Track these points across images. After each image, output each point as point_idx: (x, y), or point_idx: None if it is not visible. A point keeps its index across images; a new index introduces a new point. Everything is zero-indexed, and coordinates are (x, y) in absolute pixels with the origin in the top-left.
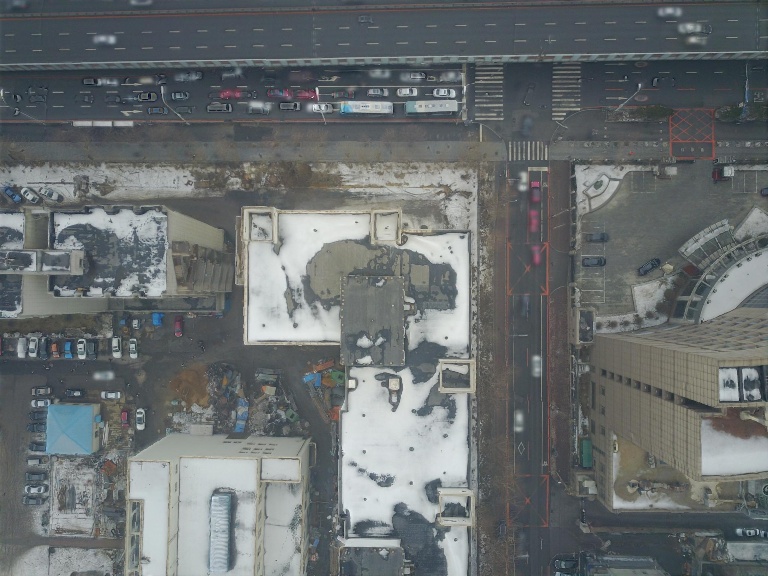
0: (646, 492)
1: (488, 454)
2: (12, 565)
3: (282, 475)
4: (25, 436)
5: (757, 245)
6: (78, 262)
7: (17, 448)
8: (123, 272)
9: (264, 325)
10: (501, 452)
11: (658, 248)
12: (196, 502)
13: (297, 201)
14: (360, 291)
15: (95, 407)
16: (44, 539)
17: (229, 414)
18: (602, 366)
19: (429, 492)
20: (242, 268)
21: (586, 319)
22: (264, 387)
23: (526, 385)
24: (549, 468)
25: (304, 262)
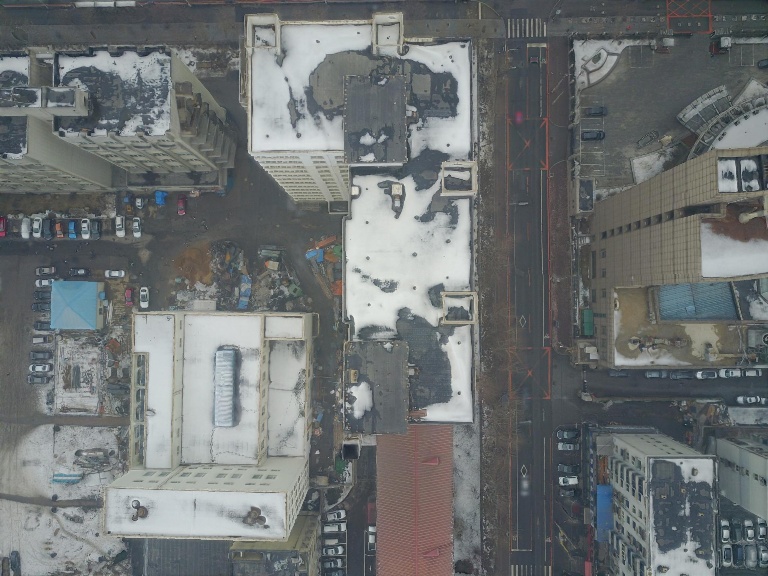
0: (647, 349)
1: (490, 327)
2: (17, 444)
3: (286, 333)
4: (29, 316)
5: (754, 105)
6: (83, 99)
7: (21, 328)
8: (127, 113)
9: (268, 136)
10: (503, 318)
11: (656, 121)
12: (200, 359)
13: None
14: (363, 90)
15: (99, 284)
16: (49, 418)
17: (232, 290)
18: (602, 229)
19: (432, 296)
20: (245, 88)
21: (586, 188)
22: (267, 262)
23: (527, 259)
24: (550, 340)
25: (307, 73)
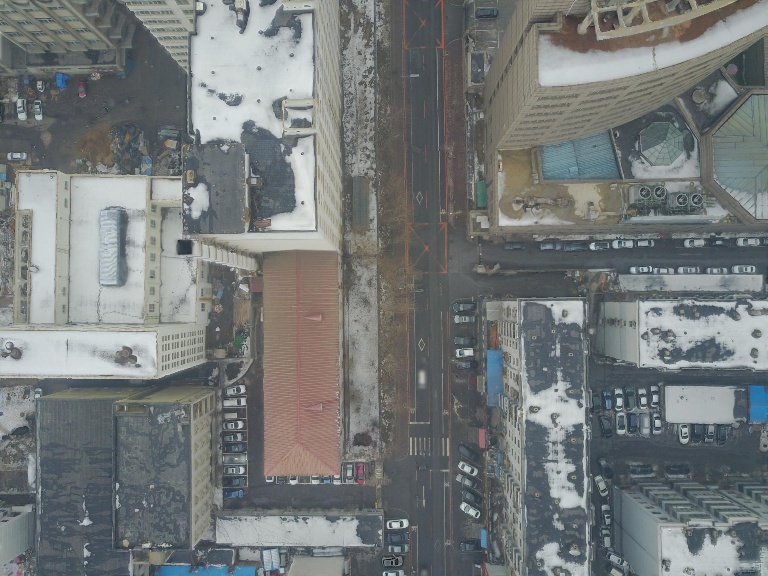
0: (531, 209)
1: None
2: None
3: (172, 196)
4: None
5: None
6: None
7: None
8: None
9: None
10: (394, 187)
11: None
12: (87, 221)
13: None
14: None
15: None
16: None
17: (132, 170)
18: (489, 96)
19: (276, 109)
20: None
21: (477, 61)
22: (166, 141)
23: (423, 136)
24: (447, 216)
25: None
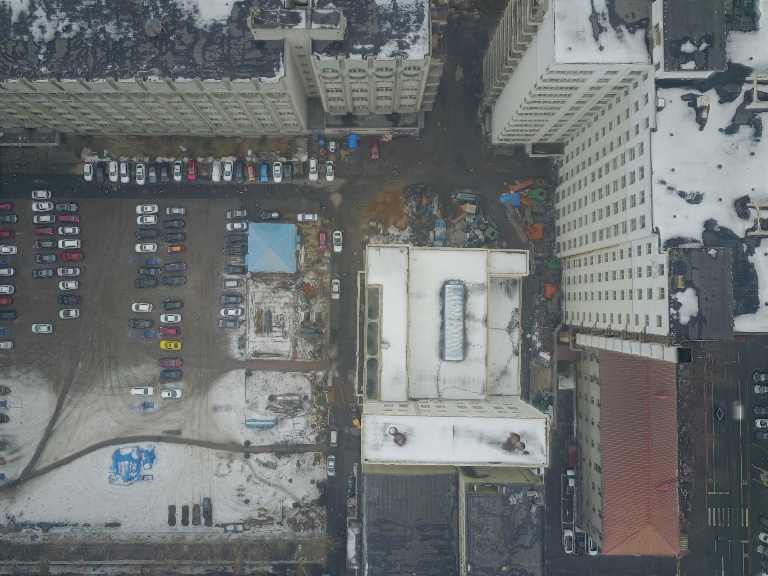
0: None
1: None
2: (208, 390)
3: (509, 269)
4: (219, 260)
5: None
6: (345, 21)
7: (211, 272)
8: (382, 38)
9: (570, 48)
10: None
11: None
12: (426, 294)
13: (491, 25)
14: None
15: None
16: (240, 363)
17: (428, 234)
18: None
19: (738, 208)
20: (533, 5)
21: None
22: (464, 206)
23: None
24: None
25: None
